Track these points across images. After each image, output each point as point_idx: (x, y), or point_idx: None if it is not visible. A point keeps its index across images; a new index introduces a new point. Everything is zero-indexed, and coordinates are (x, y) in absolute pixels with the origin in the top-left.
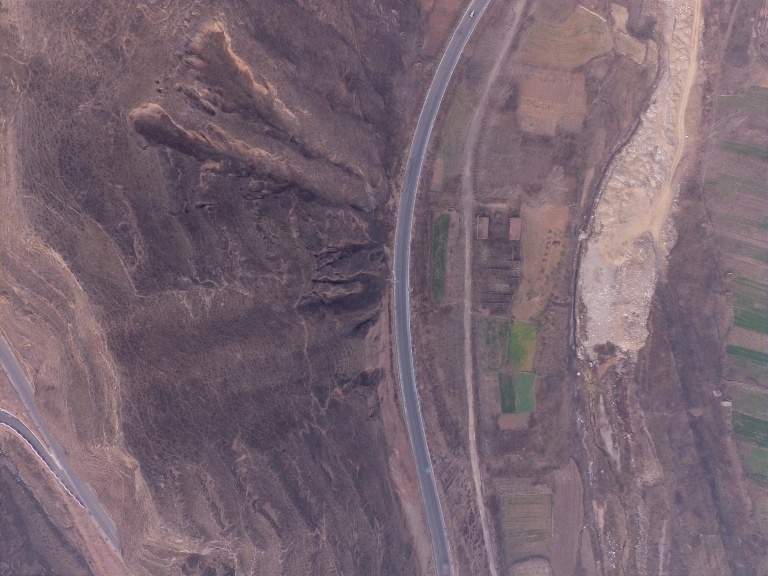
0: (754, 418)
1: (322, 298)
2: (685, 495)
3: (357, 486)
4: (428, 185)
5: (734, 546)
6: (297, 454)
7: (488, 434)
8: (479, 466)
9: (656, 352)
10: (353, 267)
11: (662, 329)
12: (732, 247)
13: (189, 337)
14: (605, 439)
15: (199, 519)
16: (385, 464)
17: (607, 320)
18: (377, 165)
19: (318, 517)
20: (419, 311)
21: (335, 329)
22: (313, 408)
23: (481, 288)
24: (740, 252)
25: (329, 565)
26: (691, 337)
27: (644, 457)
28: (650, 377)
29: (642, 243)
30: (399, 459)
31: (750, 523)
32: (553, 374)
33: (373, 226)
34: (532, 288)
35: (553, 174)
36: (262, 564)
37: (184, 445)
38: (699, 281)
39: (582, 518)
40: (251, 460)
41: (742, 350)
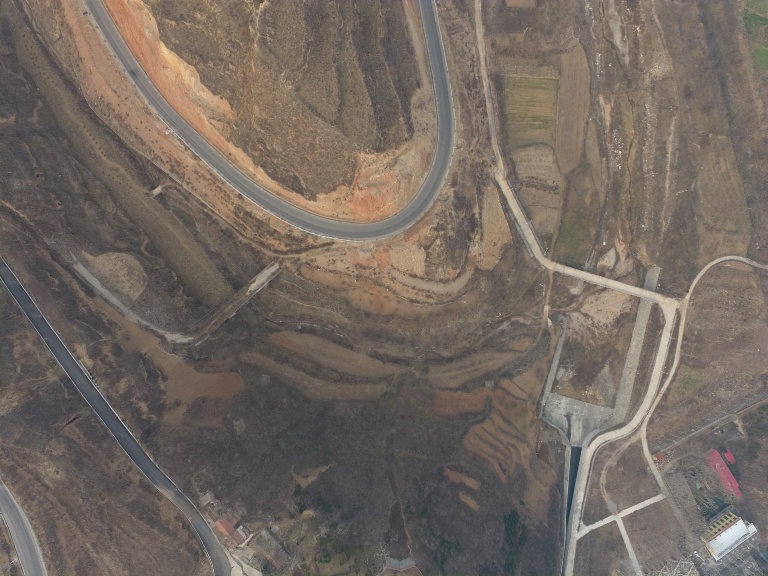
0: (766, 19)
1: None
2: (695, 90)
3: None
4: None
5: (744, 159)
6: None
7: (494, 9)
8: (484, 36)
9: None
10: None
11: None
12: None
13: None
14: (614, 31)
15: None
16: None
17: None
18: None
19: None
20: None
21: None
22: None
23: None
24: None
25: None
26: None
27: (653, 48)
28: None
29: None
30: None
31: (761, 128)
32: None
33: None
34: None
35: None
36: None
37: None
38: None
39: (588, 106)
40: None
41: None
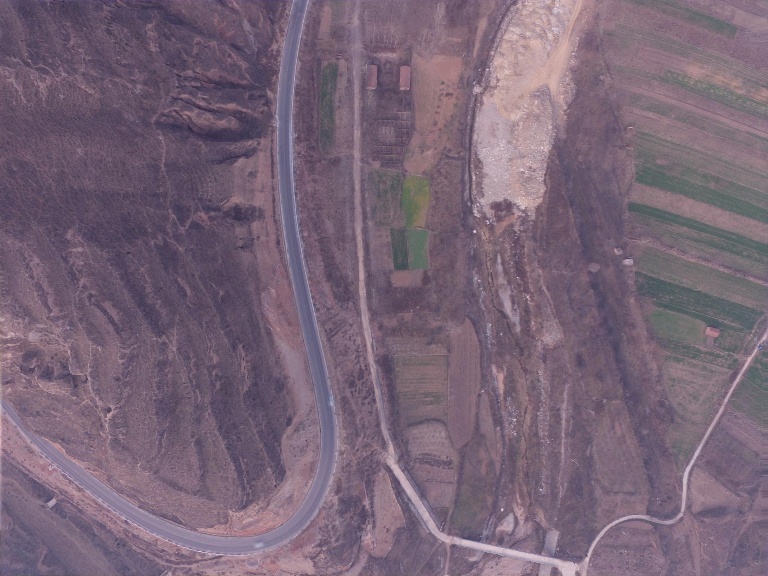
0: (659, 279)
1: (188, 123)
2: (587, 358)
3: (217, 307)
4: (315, 32)
5: (642, 416)
6: (147, 262)
7: (380, 291)
8: (370, 322)
9: (553, 207)
10: (224, 97)
11: (560, 184)
12: (632, 101)
13: (20, 120)
14: (504, 300)
15: (23, 299)
16: (255, 296)
17: (504, 176)
18: (256, 3)
19: (168, 327)
20: (304, 158)
21: (200, 153)
22: (171, 225)
23: (371, 139)
24: (641, 106)
25: (182, 380)
26: (591, 194)
27: (543, 318)
28: (548, 233)
29: (538, 95)
30: (275, 299)
31: (656, 389)
32: (447, 230)
33: (254, 68)
34: (425, 141)
35: (438, 15)
36: (101, 363)
37: (7, 221)
38: (598, 135)
39: (479, 380)
40: (89, 255)
41: (645, 208)
